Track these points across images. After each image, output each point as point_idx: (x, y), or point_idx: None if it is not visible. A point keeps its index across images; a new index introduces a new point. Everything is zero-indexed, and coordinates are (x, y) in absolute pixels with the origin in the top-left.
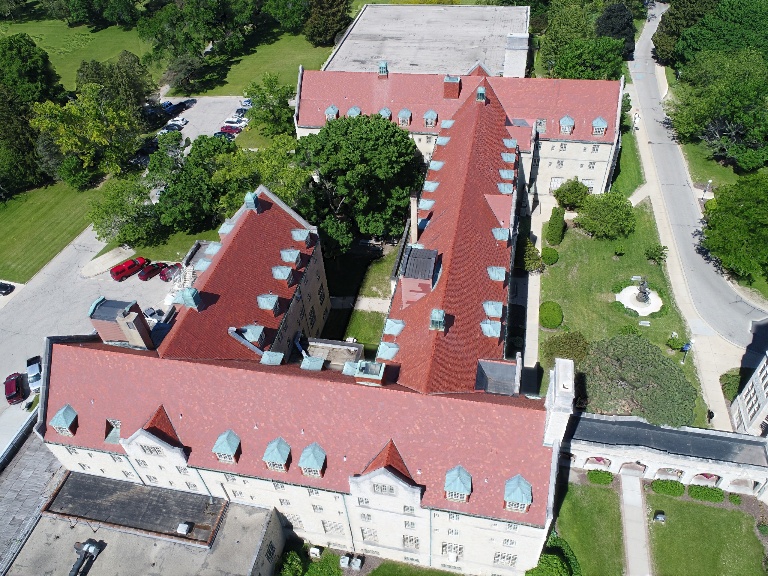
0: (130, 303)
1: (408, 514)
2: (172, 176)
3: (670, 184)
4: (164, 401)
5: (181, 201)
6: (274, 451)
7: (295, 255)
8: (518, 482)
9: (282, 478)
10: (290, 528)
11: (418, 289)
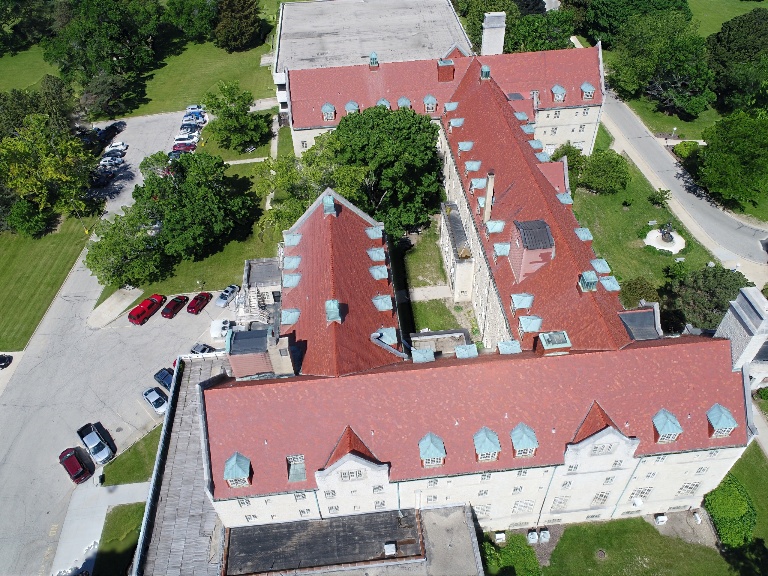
0: (267, 330)
1: (615, 469)
2: (174, 200)
3: (635, 137)
4: (350, 421)
5: (189, 226)
6: (486, 441)
7: (382, 253)
8: (720, 410)
9: (494, 467)
10: (475, 520)
11: (538, 259)
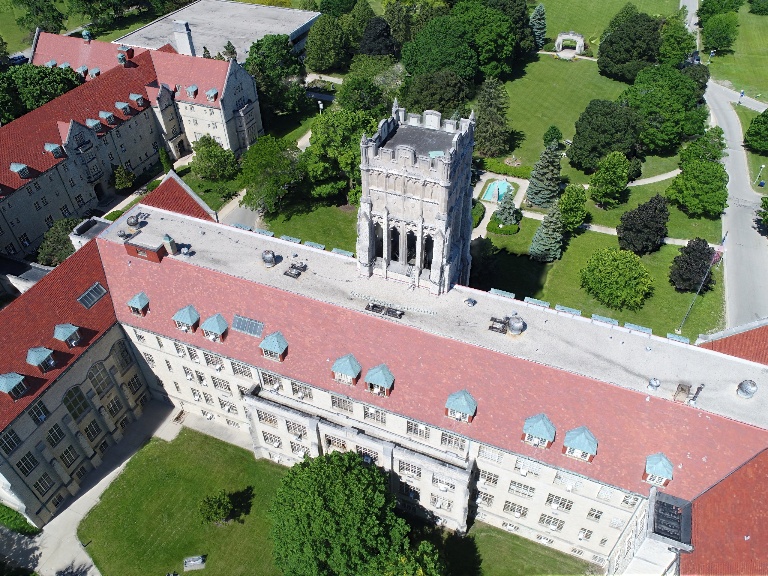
0: None
1: None
2: None
3: None
4: None
5: None
6: None
7: None
8: None
9: None
10: None
11: None
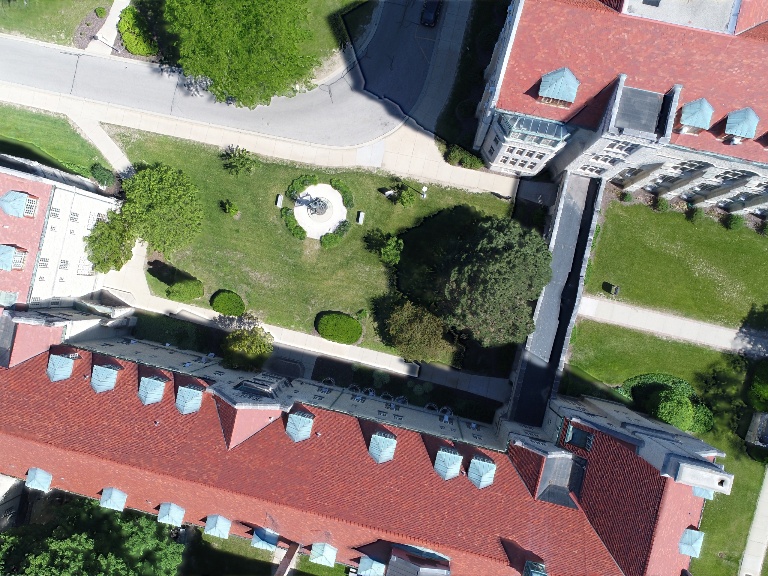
0: None
1: None
2: None
3: (72, 81)
4: None
5: None
6: None
7: None
8: None
9: None
10: None
11: None
